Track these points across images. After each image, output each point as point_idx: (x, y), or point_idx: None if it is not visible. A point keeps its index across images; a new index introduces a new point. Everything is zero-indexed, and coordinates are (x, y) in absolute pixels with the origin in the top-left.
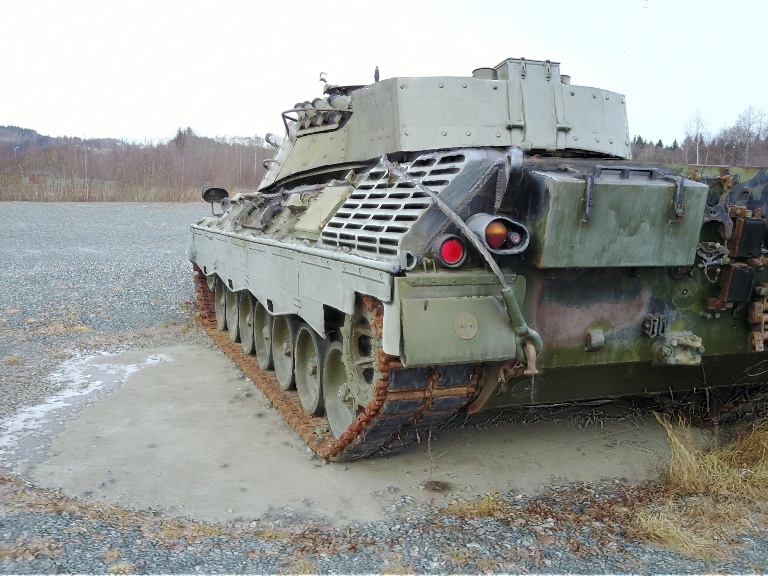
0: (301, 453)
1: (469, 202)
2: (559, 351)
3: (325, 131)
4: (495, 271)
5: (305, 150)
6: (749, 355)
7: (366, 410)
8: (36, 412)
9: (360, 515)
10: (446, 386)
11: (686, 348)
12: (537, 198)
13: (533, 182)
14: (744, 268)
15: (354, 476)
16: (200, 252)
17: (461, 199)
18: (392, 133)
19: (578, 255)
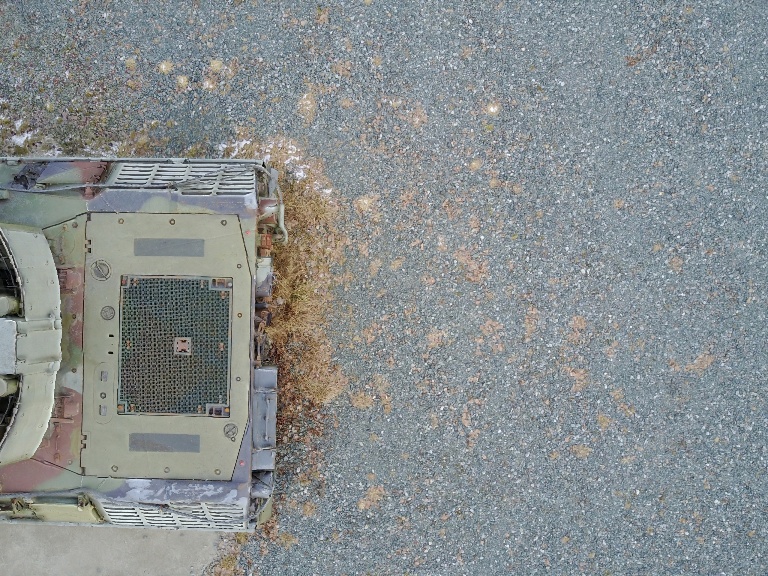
0: None
1: None
2: None
3: None
4: None
5: None
6: None
7: None
8: None
9: None
10: None
11: None
12: None
13: None
14: None
15: None
16: None
17: None
18: None
19: None
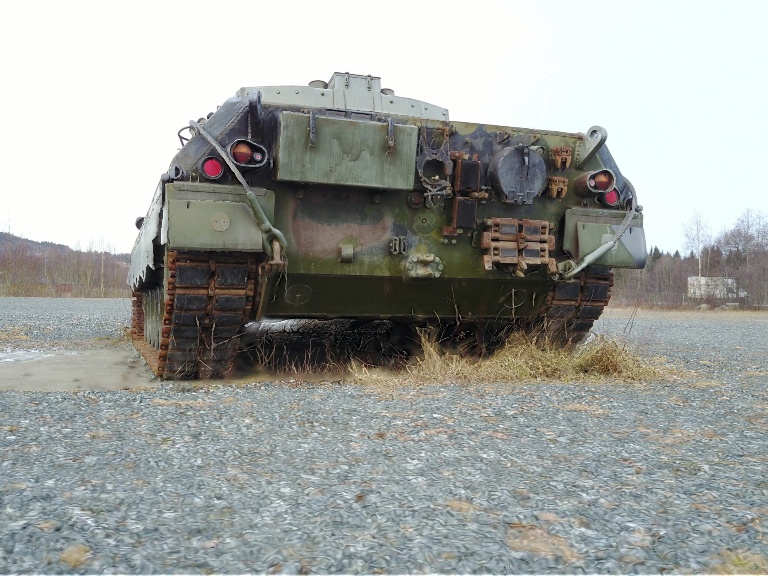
0: (146, 379)
1: (227, 133)
2: (316, 260)
3: None
4: (239, 178)
5: None
6: (494, 282)
7: None
8: None
9: None
10: (225, 286)
11: (426, 265)
12: (277, 129)
13: (275, 119)
14: (468, 200)
15: None
16: None
17: (220, 130)
18: None
19: (310, 172)
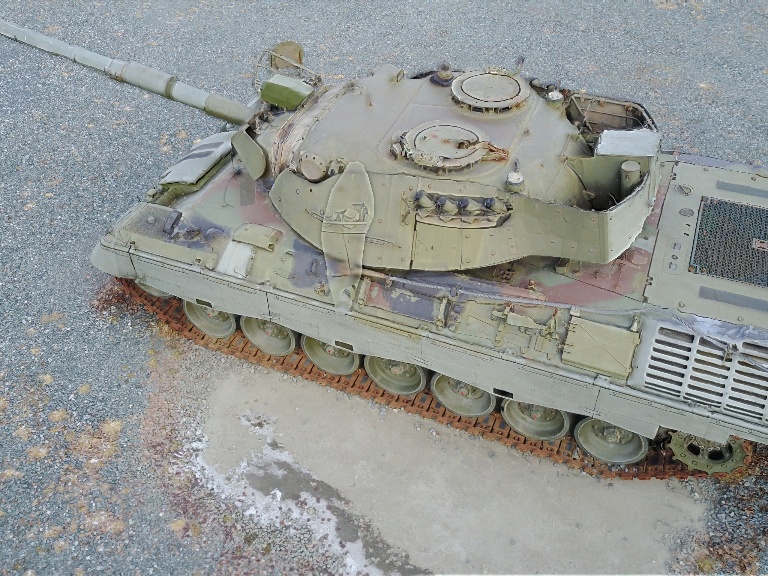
0: (583, 479)
1: None
2: None
3: (480, 228)
4: None
5: (457, 246)
6: None
7: (715, 476)
8: (365, 571)
9: (693, 512)
10: None
11: None
12: None
13: None
14: None
15: (638, 480)
16: (177, 285)
17: None
18: (598, 251)
19: None
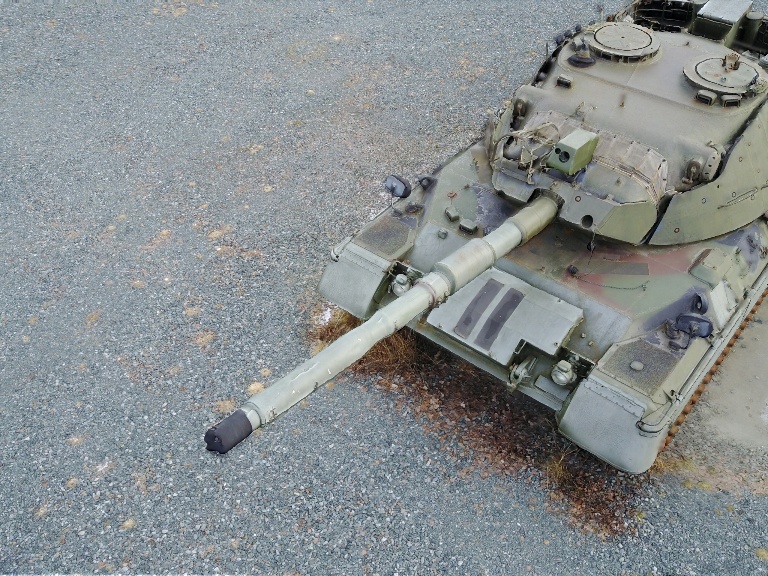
0: None
1: None
2: None
3: None
4: None
5: None
6: None
7: None
8: None
9: None
10: None
11: None
12: None
13: None
14: None
15: None
16: None
17: None
18: None
19: None
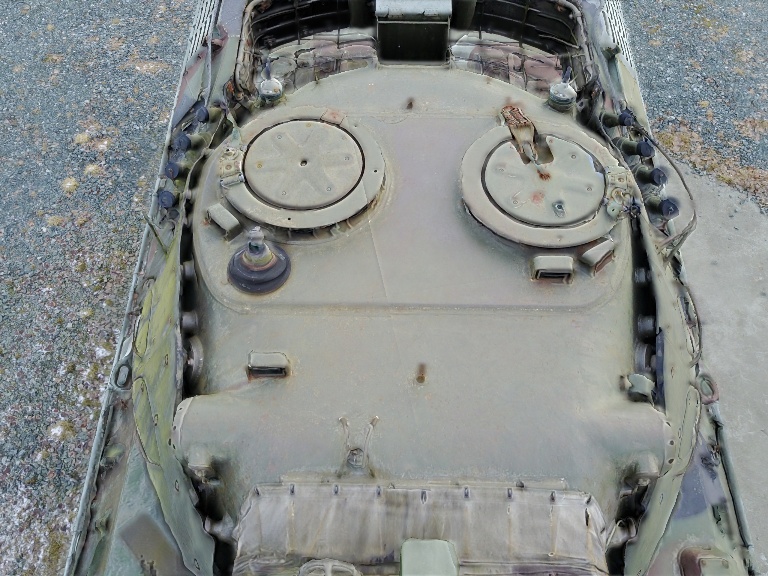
0: None
1: None
2: None
3: None
4: None
5: None
6: None
7: None
8: None
9: None
10: None
11: None
12: None
13: None
14: None
15: None
16: None
17: None
18: None
19: None
